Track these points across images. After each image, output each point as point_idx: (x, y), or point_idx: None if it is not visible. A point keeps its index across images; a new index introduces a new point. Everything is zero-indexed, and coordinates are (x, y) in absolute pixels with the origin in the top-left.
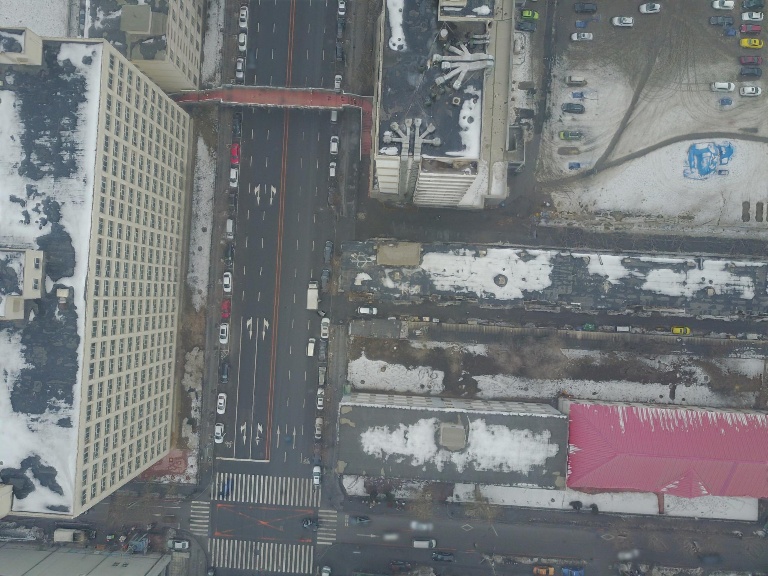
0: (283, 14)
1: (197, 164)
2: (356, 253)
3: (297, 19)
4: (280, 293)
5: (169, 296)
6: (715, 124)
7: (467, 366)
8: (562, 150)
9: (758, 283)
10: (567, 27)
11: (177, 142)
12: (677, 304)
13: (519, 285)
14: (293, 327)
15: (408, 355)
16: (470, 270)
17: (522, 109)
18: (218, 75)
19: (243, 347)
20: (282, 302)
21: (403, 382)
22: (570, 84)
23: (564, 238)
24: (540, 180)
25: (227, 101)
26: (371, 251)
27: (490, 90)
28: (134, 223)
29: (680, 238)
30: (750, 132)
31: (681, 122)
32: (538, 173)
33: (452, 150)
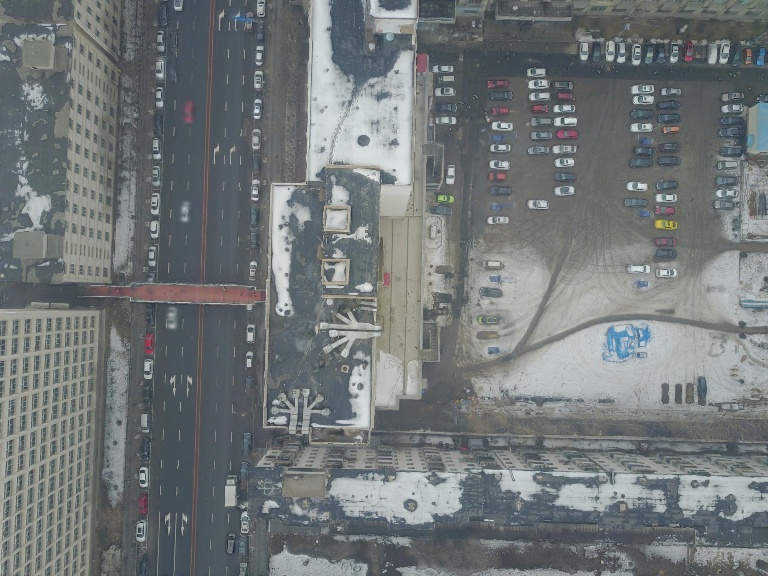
0: (196, 200)
1: (110, 356)
2: (263, 480)
3: (210, 204)
4: (198, 487)
5: (79, 506)
6: (632, 306)
7: (391, 557)
8: (481, 334)
9: (670, 496)
10: (483, 210)
11: (84, 348)
12: (590, 519)
13: (429, 509)
14: (212, 521)
15: (330, 548)
16: (379, 495)
17: (440, 293)
18: (130, 264)
19: (161, 543)
20: (201, 496)
21: (326, 575)
22: (487, 268)
23: (485, 424)
24: (460, 365)
25: (137, 299)
26: (278, 478)
27: (403, 287)
28: (27, 468)
29: (601, 421)
30: (667, 313)
31: (599, 304)
32: (458, 358)
33: (342, 418)
